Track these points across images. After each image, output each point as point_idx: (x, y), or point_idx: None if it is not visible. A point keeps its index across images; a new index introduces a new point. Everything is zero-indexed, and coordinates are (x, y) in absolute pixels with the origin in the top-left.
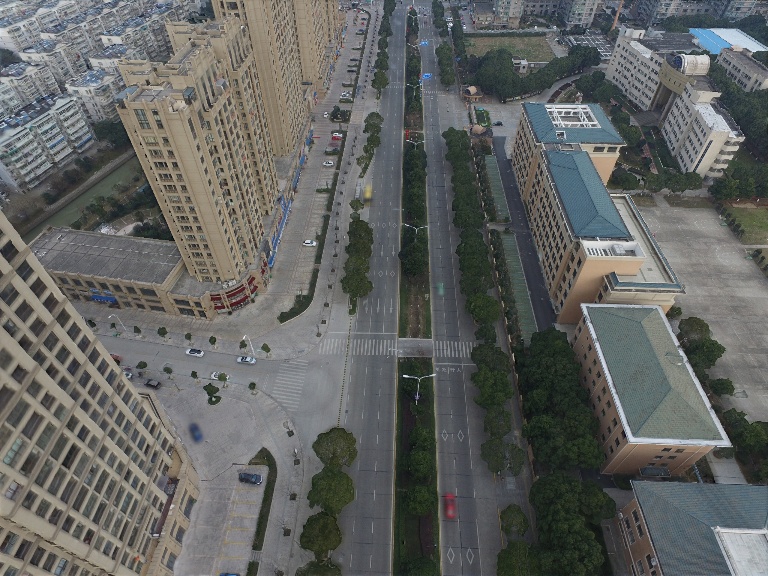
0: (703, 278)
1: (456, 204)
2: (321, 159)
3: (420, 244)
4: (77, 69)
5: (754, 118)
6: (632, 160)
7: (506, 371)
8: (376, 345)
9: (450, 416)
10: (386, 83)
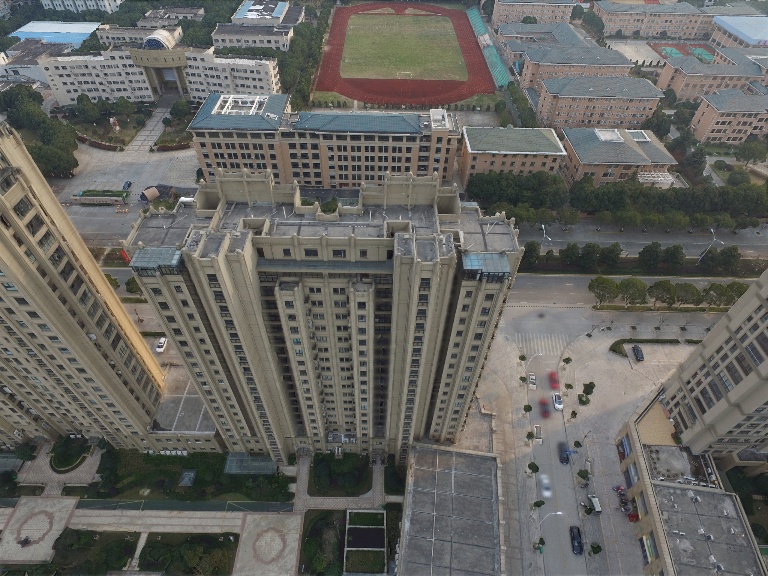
0: None
1: None
2: None
3: None
4: None
5: None
6: None
7: None
8: None
9: None
10: None
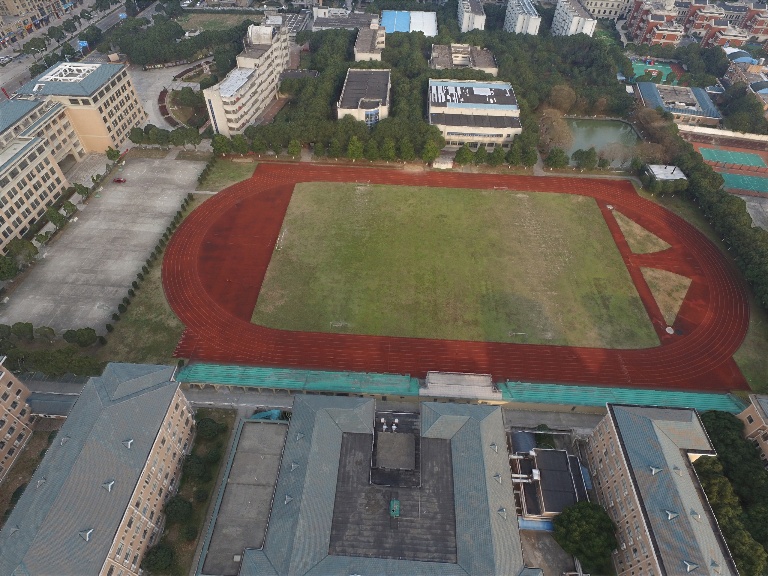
0: (121, 215)
1: None
2: None
3: None
4: None
5: (306, 85)
6: (192, 120)
7: None
8: None
9: None
10: None
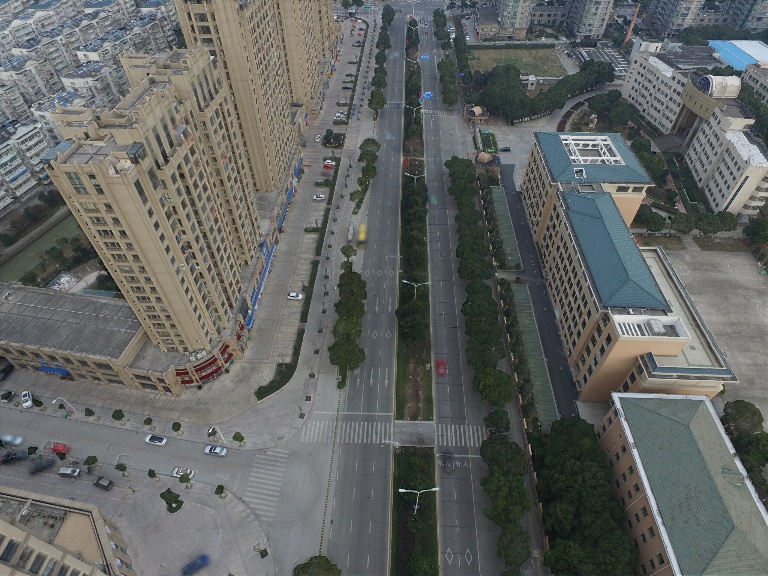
0: (745, 341)
1: (461, 251)
2: (311, 191)
3: (420, 302)
4: (50, 87)
5: None
6: (655, 193)
7: (523, 474)
8: (368, 430)
9: (456, 529)
10: (384, 103)
